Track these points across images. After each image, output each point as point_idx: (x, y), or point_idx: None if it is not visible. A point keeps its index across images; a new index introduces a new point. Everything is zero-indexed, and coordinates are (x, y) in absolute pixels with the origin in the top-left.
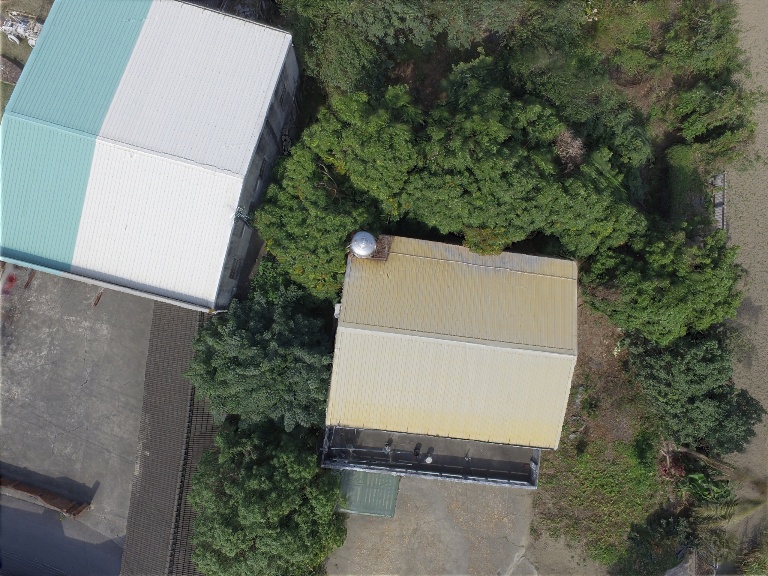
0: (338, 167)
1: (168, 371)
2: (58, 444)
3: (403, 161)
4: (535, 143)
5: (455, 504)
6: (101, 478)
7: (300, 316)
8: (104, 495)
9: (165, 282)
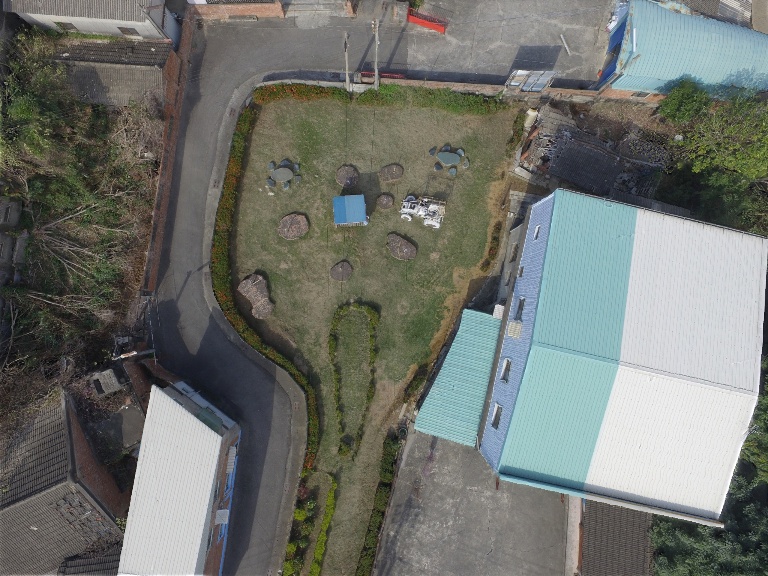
0: None
1: (614, 556)
2: None
3: None
4: None
5: None
6: None
7: (767, 509)
8: None
9: (673, 496)
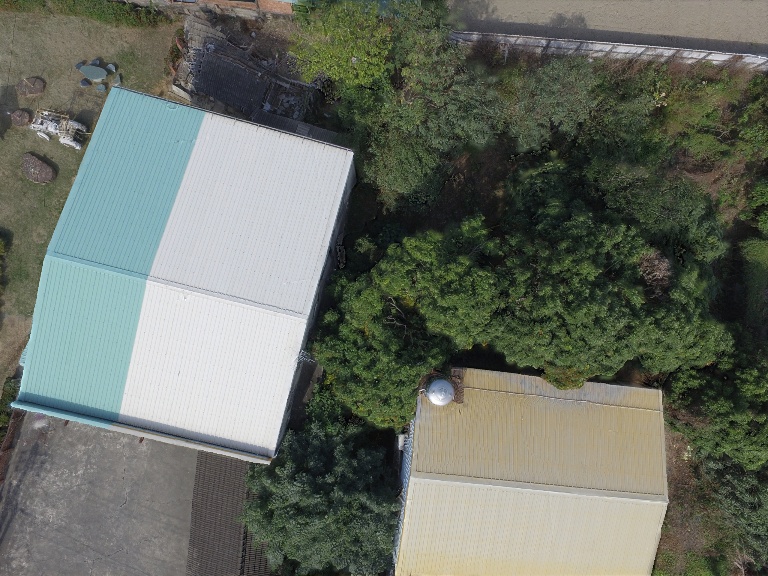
0: (406, 297)
1: (218, 504)
2: (96, 570)
3: (485, 304)
4: (619, 267)
5: None
6: None
7: (362, 451)
8: None
9: (221, 430)
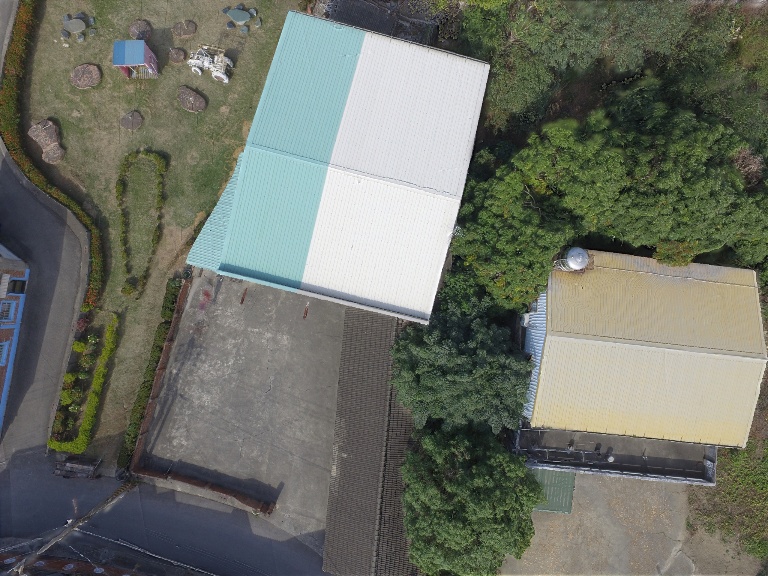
0: (538, 187)
1: (363, 378)
2: (246, 448)
3: (616, 181)
4: (720, 160)
5: (615, 501)
6: (285, 479)
7: (495, 325)
8: (288, 495)
9: (386, 297)
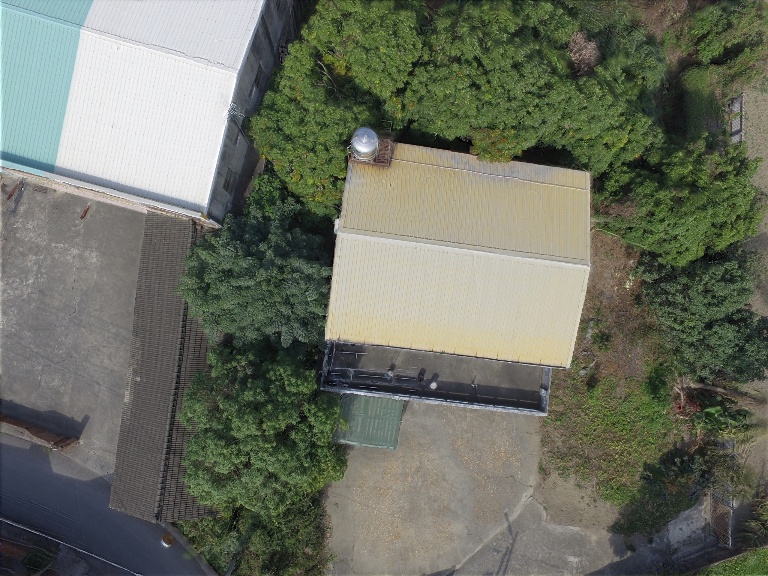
0: (338, 67)
1: (159, 292)
2: (45, 376)
3: (407, 50)
4: (546, 43)
5: (460, 441)
6: (90, 412)
7: (298, 230)
8: (94, 430)
9: (154, 185)
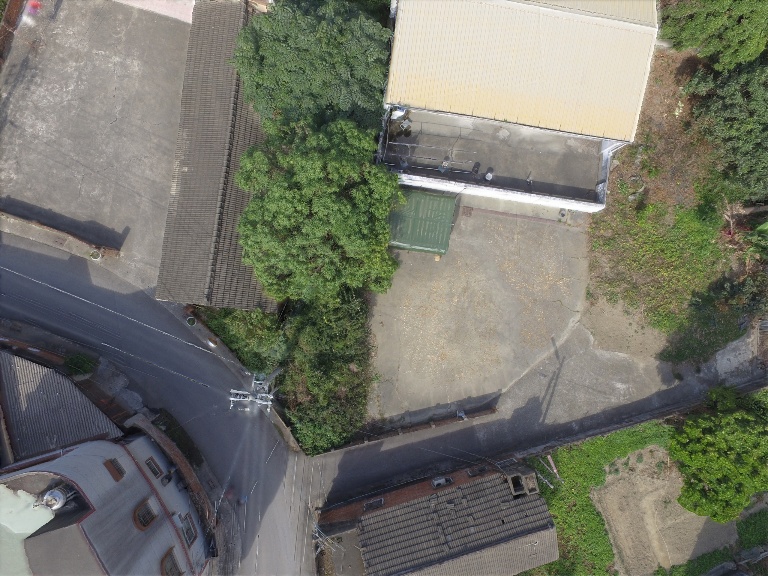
0: None
1: (208, 79)
2: (86, 185)
3: None
4: None
5: (507, 263)
6: (131, 223)
7: (354, 5)
8: (134, 242)
9: None
